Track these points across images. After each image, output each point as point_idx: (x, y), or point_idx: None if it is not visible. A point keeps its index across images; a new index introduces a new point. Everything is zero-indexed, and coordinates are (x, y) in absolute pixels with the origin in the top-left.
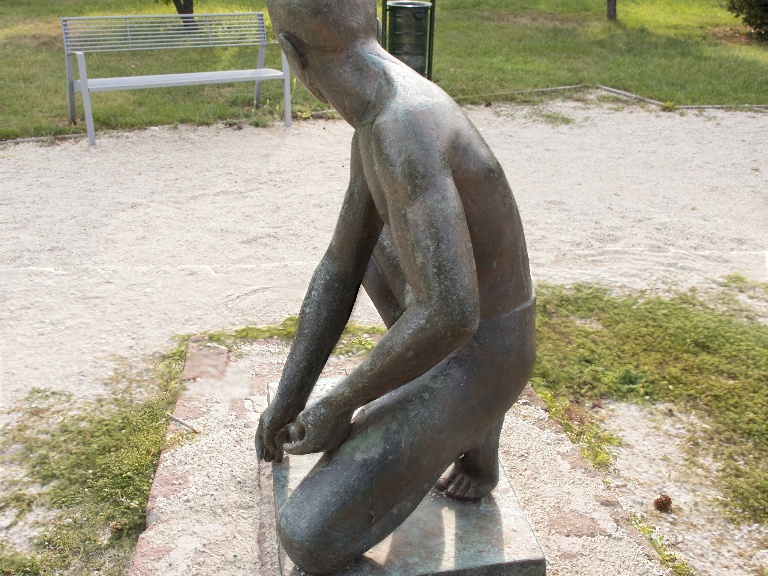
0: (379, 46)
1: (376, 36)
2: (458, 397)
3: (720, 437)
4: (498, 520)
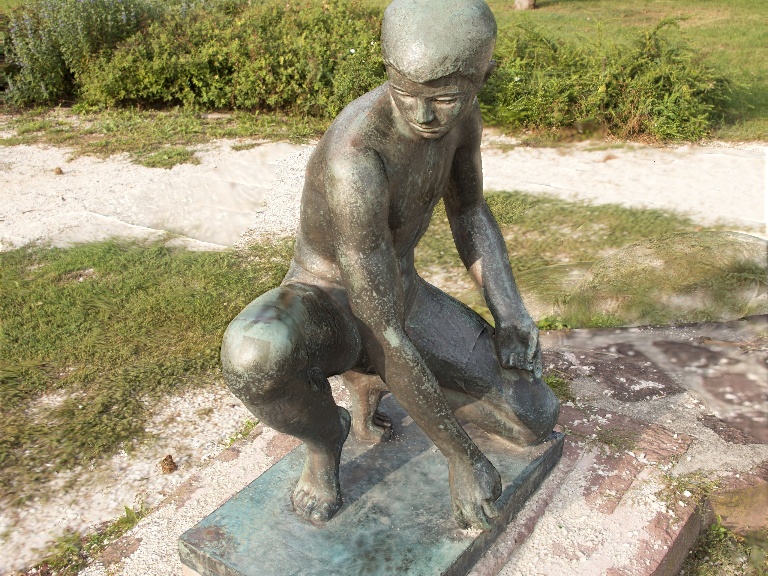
0: None
1: None
2: None
3: (5, 489)
4: (386, 400)
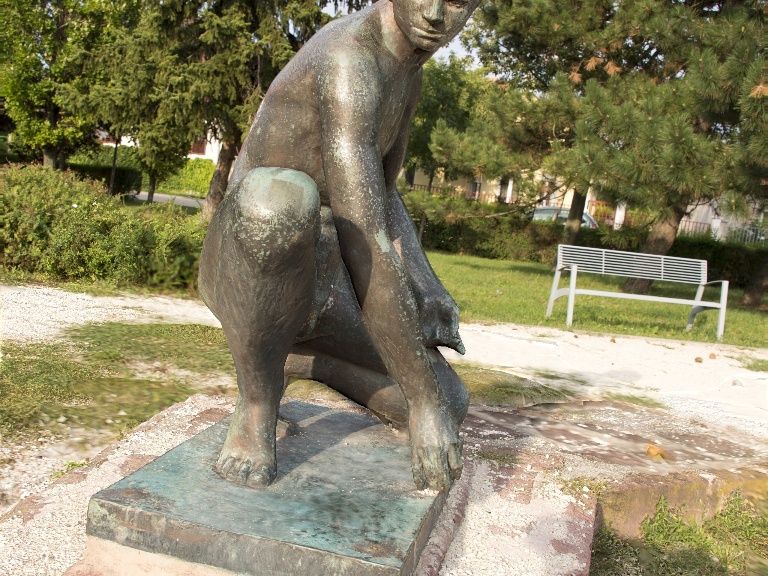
0: None
1: None
2: None
3: None
4: None
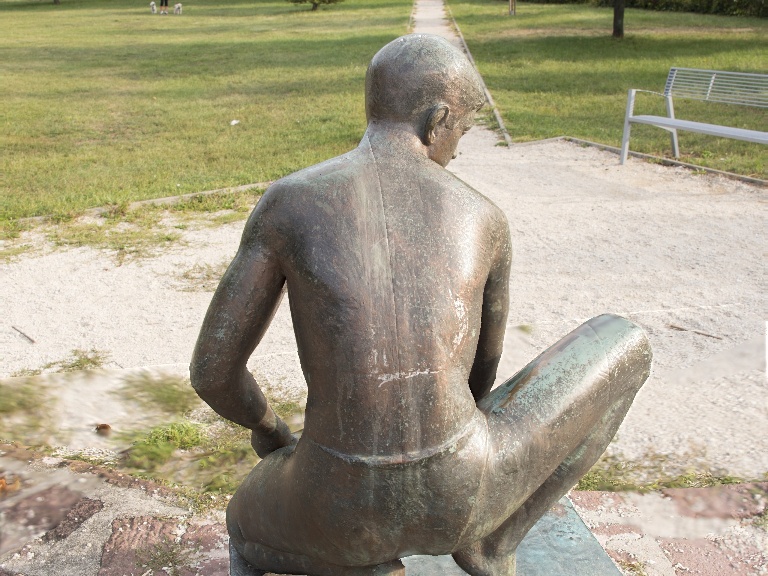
0: (391, 129)
1: (413, 121)
2: (274, 484)
3: None
4: None
